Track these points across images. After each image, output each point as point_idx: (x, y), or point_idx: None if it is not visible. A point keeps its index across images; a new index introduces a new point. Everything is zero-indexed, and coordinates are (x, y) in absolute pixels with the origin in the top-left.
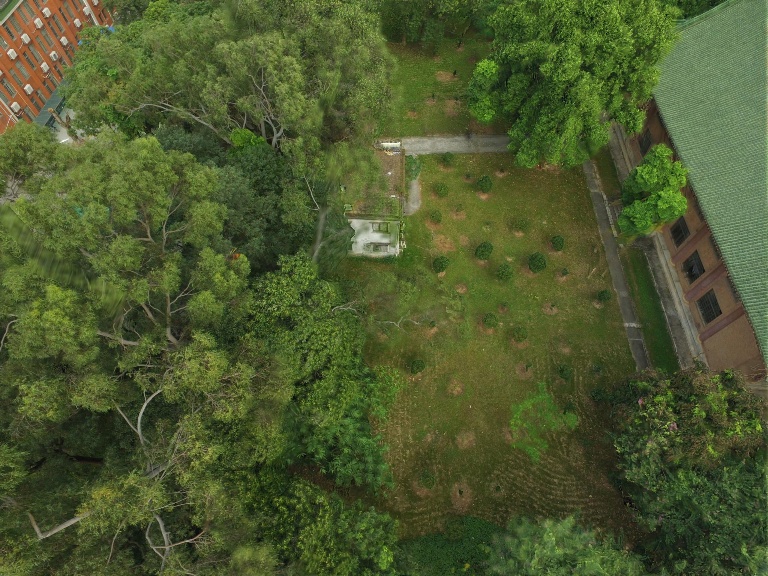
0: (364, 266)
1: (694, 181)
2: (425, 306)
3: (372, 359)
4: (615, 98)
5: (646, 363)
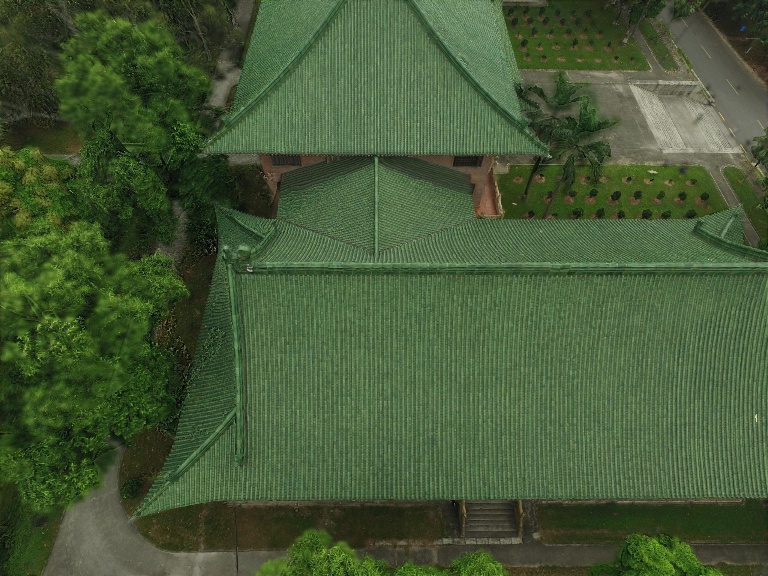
0: None
1: (589, 494)
2: None
3: None
4: None
5: (716, 548)
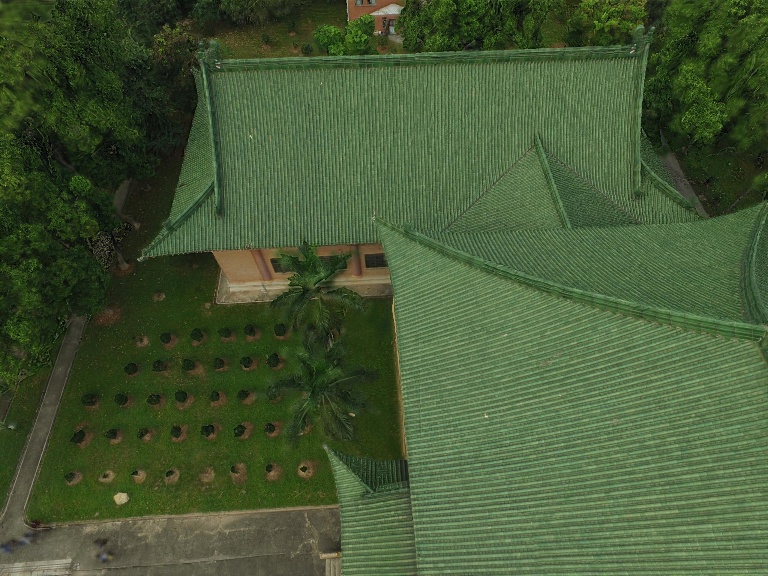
0: (341, 23)
1: None
2: (312, 47)
3: (275, 30)
4: (432, 7)
5: None
